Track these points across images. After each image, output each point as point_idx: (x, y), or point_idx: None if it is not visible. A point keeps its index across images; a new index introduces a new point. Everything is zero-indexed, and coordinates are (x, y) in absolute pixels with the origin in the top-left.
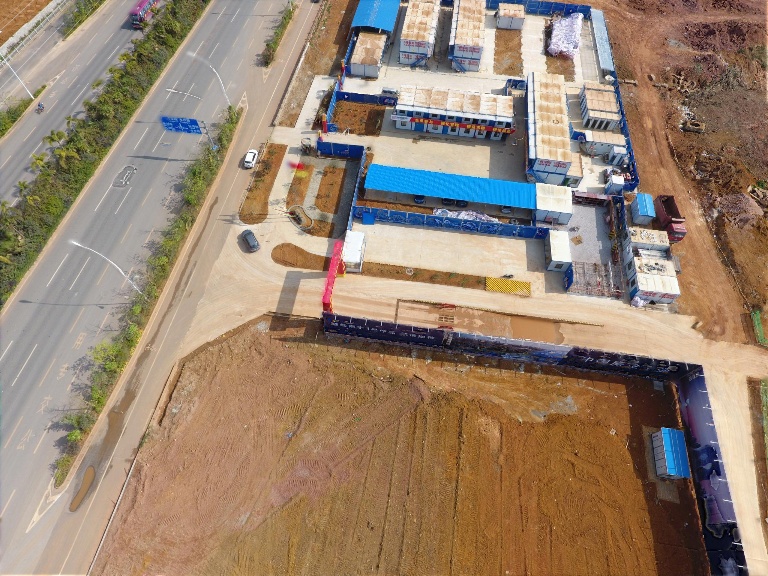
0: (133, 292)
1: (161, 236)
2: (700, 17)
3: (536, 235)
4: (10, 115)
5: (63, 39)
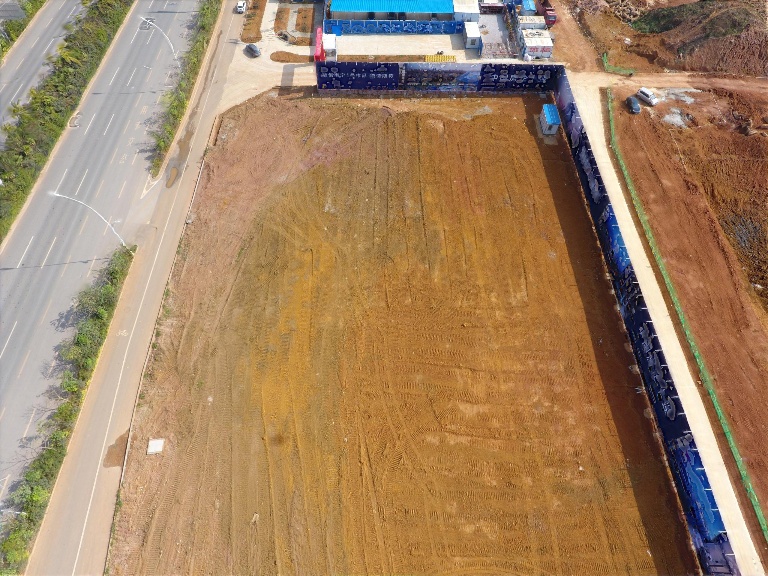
0: (175, 83)
1: (186, 54)
2: None
3: (456, 30)
4: None
5: None
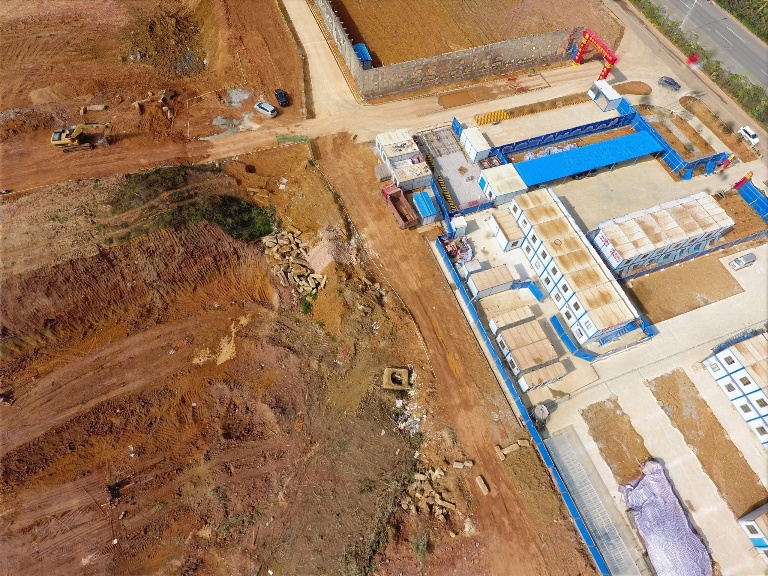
0: None
1: None
2: None
3: None
4: None
5: None
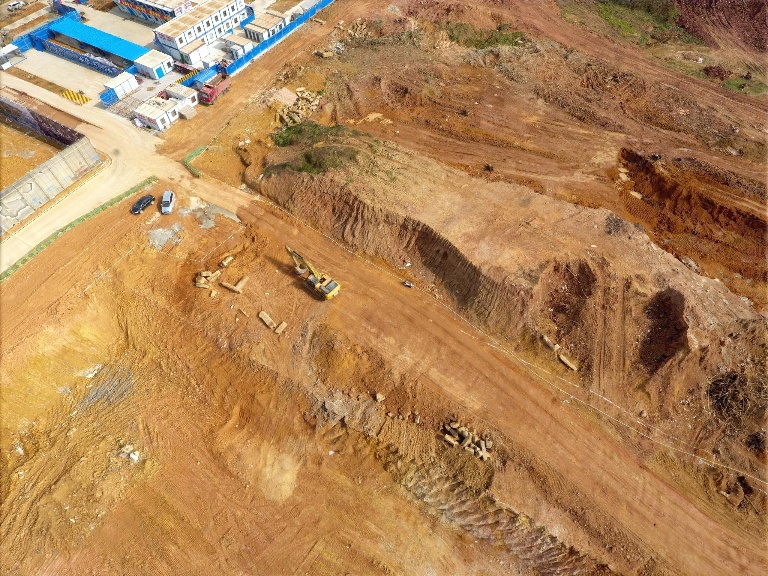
0: None
1: None
2: None
3: None
4: None
5: None
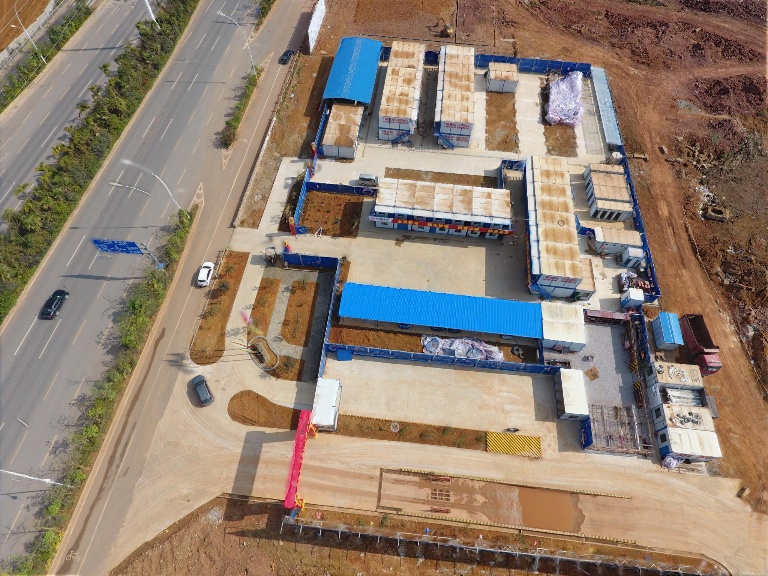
0: (55, 472)
1: (94, 388)
2: (710, 70)
3: (544, 371)
4: None
5: None
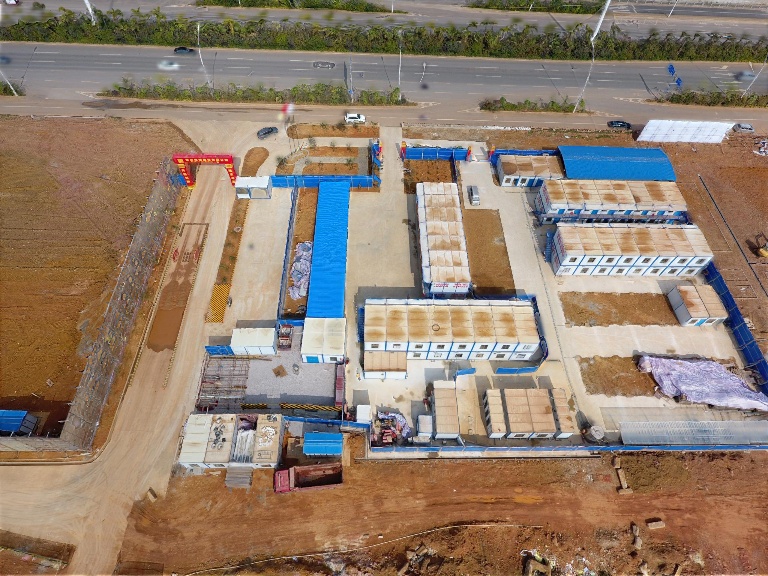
0: None
1: None
2: None
3: (279, 325)
4: (367, 6)
5: (462, 6)
